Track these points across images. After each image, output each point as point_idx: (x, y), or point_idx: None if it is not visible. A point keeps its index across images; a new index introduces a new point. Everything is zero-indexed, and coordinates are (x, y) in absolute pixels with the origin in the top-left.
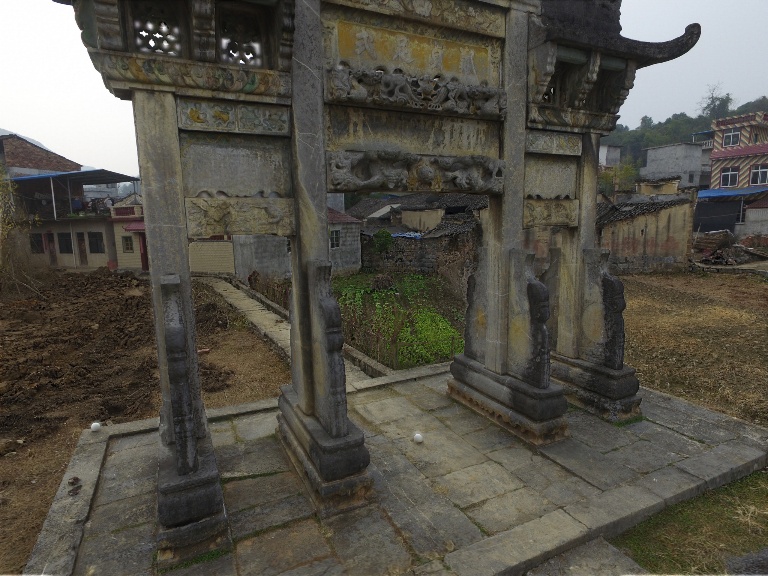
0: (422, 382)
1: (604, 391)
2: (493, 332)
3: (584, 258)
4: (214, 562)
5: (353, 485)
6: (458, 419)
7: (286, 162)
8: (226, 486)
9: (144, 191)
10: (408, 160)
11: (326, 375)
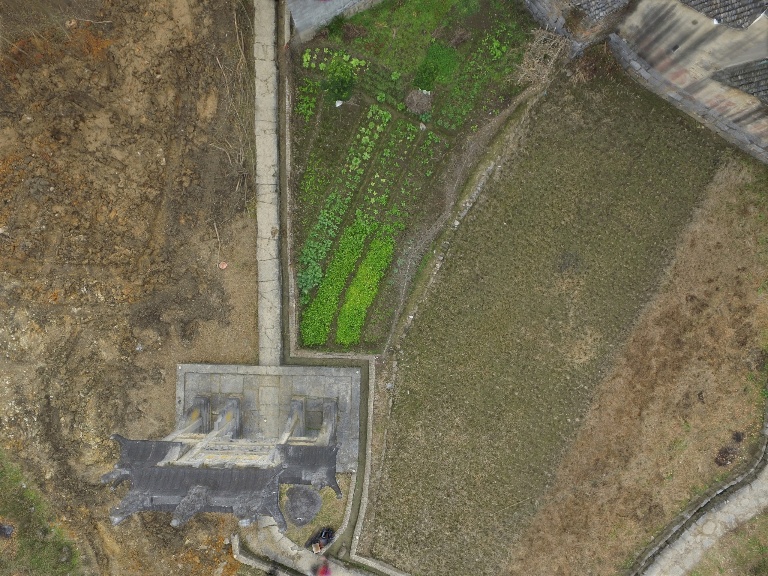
0: (294, 378)
1: None
2: None
3: None
4: None
5: None
6: (285, 414)
7: None
8: (213, 416)
9: None
10: None
11: None
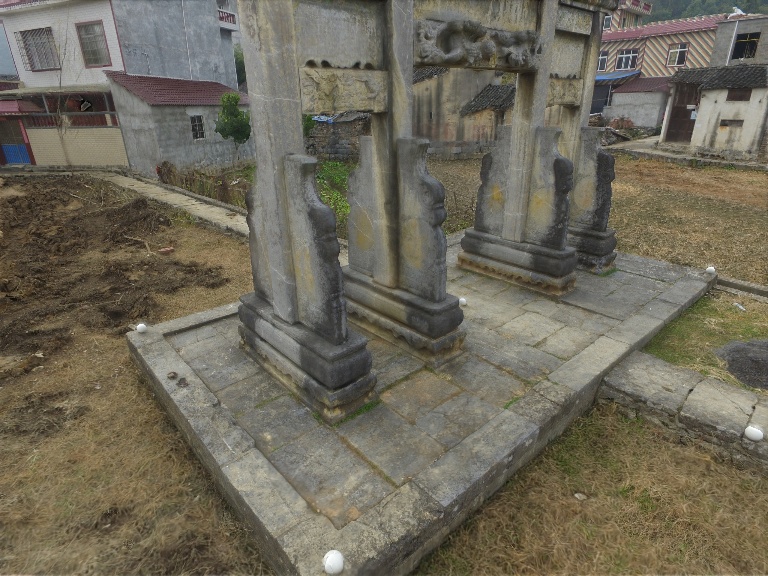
0: None
1: (593, 250)
2: (514, 206)
3: (581, 136)
4: (373, 411)
5: (454, 339)
6: (480, 284)
7: (379, 29)
8: None
9: (265, 58)
10: (479, 33)
11: (429, 248)
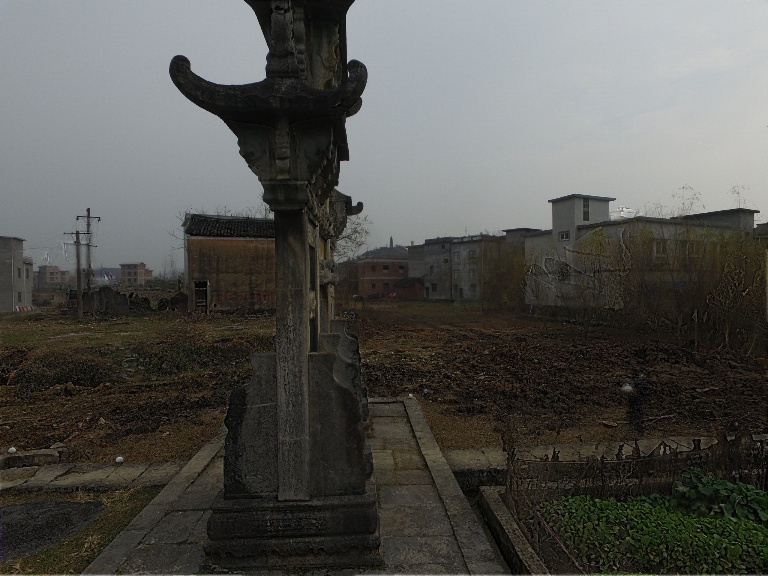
0: (425, 486)
1: None
2: None
3: None
4: None
5: None
6: None
7: None
8: None
9: None
10: None
11: None
